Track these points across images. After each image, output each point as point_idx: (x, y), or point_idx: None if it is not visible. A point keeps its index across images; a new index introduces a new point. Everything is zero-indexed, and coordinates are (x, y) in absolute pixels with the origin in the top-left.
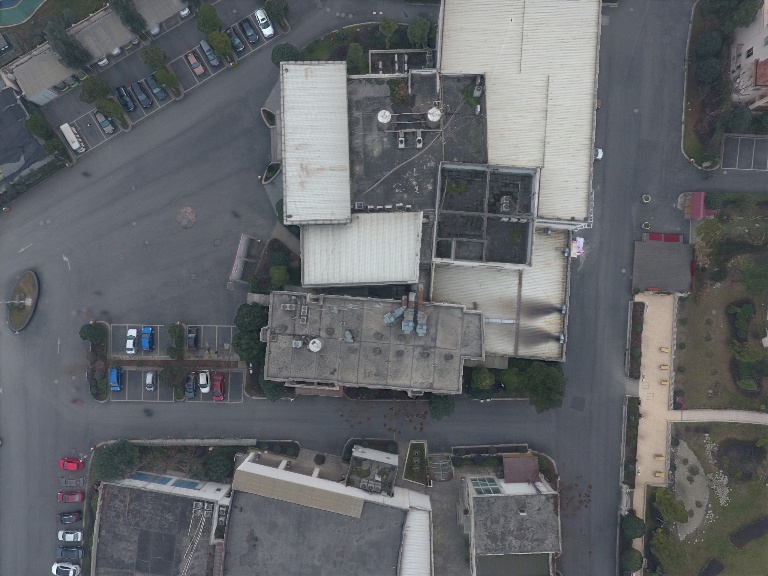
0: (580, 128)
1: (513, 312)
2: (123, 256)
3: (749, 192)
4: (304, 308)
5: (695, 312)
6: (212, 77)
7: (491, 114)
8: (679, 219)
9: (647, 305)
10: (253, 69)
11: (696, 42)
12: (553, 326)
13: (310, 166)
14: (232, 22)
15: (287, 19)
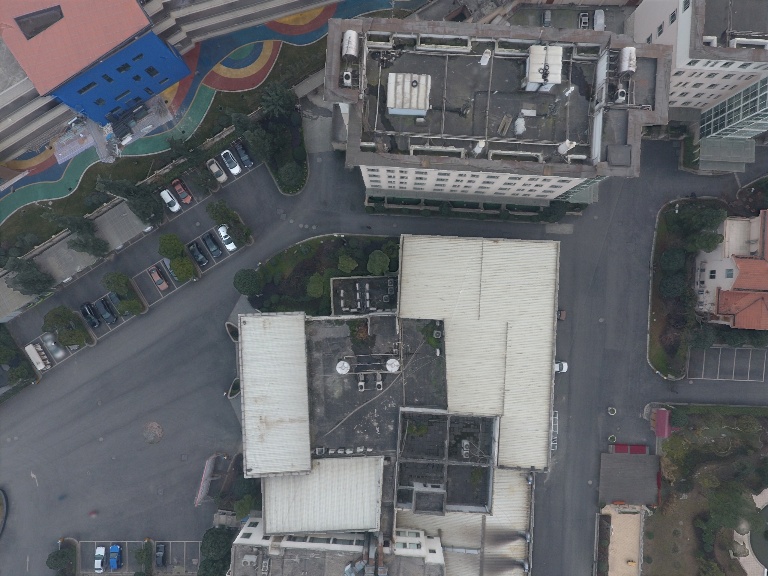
0: (539, 376)
1: (478, 540)
2: (90, 472)
3: (715, 402)
4: (265, 564)
5: (662, 524)
6: (176, 291)
7: (450, 361)
8: (645, 430)
9: (612, 528)
10: (217, 282)
11: (661, 251)
12: (518, 553)
13: (269, 418)
14: (195, 235)
15: None
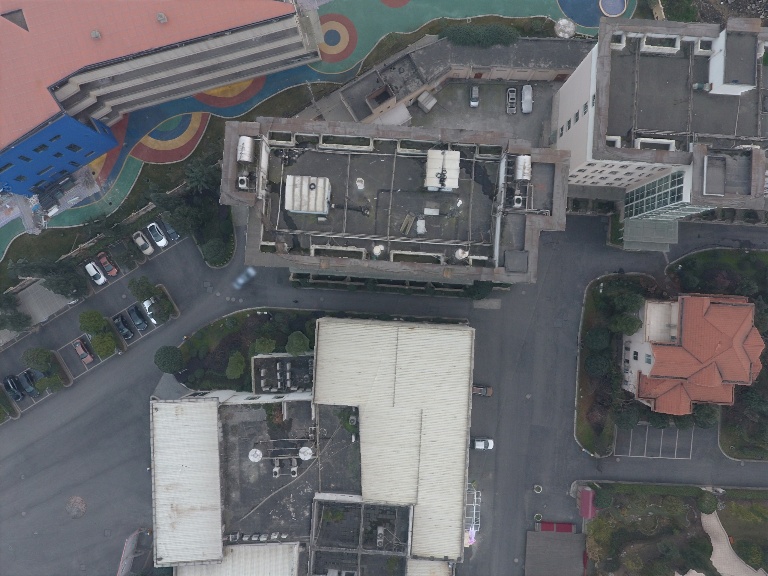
0: (453, 465)
1: None
2: (12, 547)
3: (642, 480)
4: None
5: None
6: (101, 364)
7: (365, 448)
8: (572, 507)
9: None
10: (143, 355)
11: (588, 327)
12: None
13: (181, 506)
14: (121, 307)
15: (177, 304)
